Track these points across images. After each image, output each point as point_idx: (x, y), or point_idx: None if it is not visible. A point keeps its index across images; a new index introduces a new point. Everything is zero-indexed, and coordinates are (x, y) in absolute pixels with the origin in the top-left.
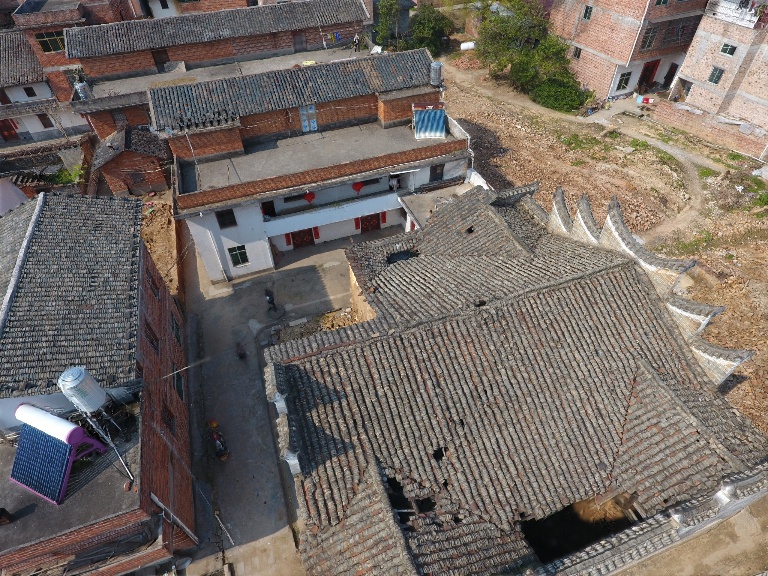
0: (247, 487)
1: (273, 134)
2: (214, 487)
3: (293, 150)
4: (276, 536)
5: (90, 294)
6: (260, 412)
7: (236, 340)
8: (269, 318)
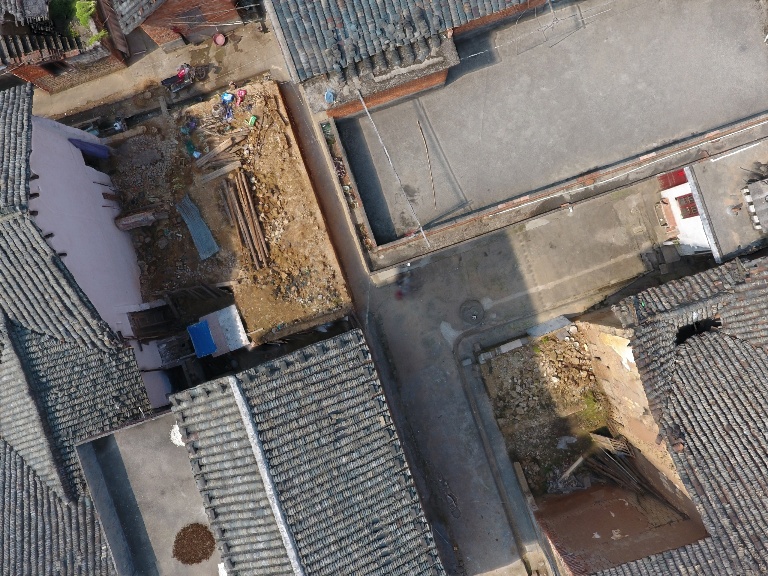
0: (478, 526)
1: (491, 23)
2: (447, 526)
3: (531, 72)
4: (511, 567)
5: (390, 570)
6: (476, 450)
7: (431, 355)
8: (465, 322)
